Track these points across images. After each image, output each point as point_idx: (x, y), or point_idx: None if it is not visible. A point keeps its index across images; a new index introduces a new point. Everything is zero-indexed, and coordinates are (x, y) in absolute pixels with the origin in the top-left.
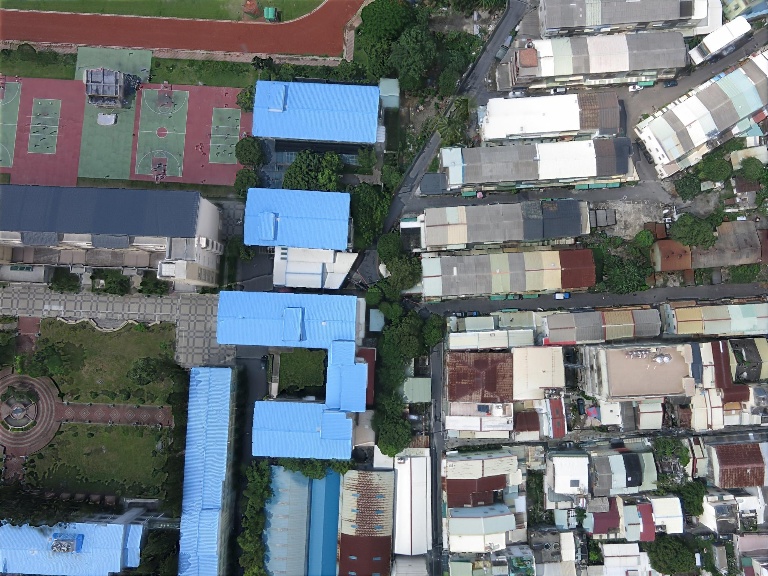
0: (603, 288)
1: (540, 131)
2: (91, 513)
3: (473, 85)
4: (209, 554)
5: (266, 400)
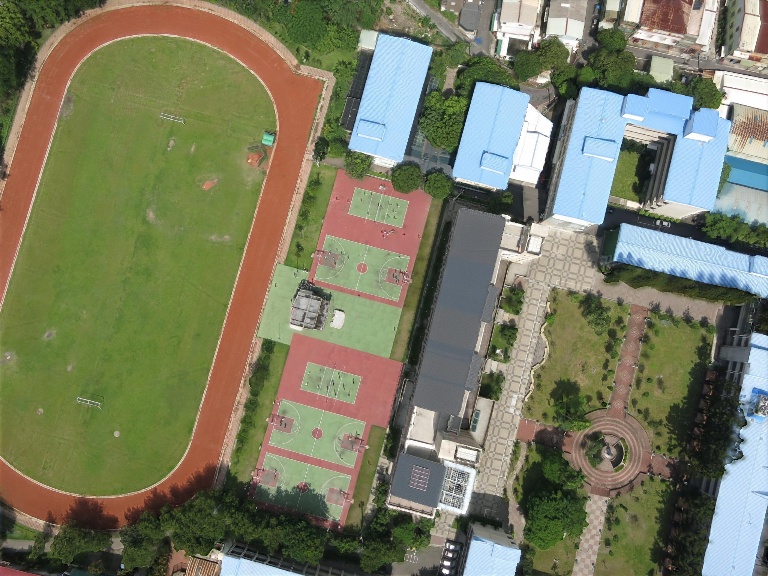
0: None
1: None
2: None
3: None
4: None
5: (652, 202)
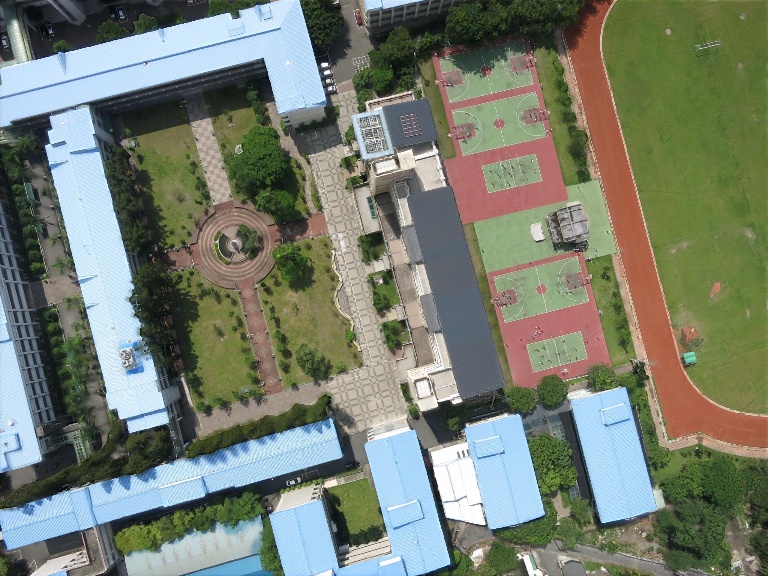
0: None
1: None
2: None
3: None
4: (163, 500)
5: None
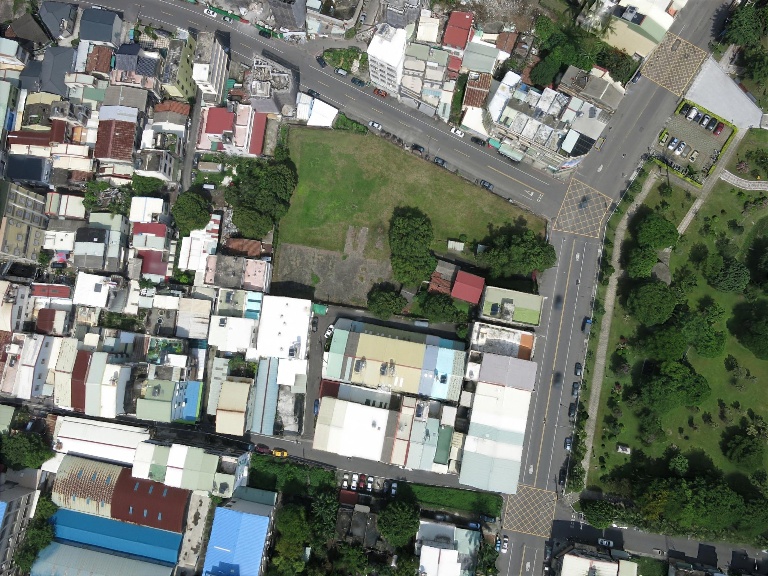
0: None
1: None
2: None
3: None
4: None
5: None
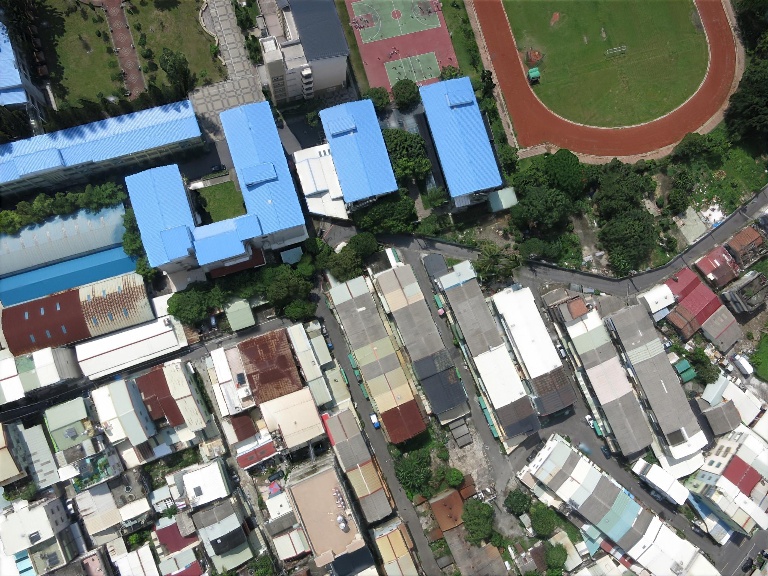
0: (395, 455)
1: (517, 343)
2: (25, 55)
3: (538, 273)
4: (18, 169)
5: None
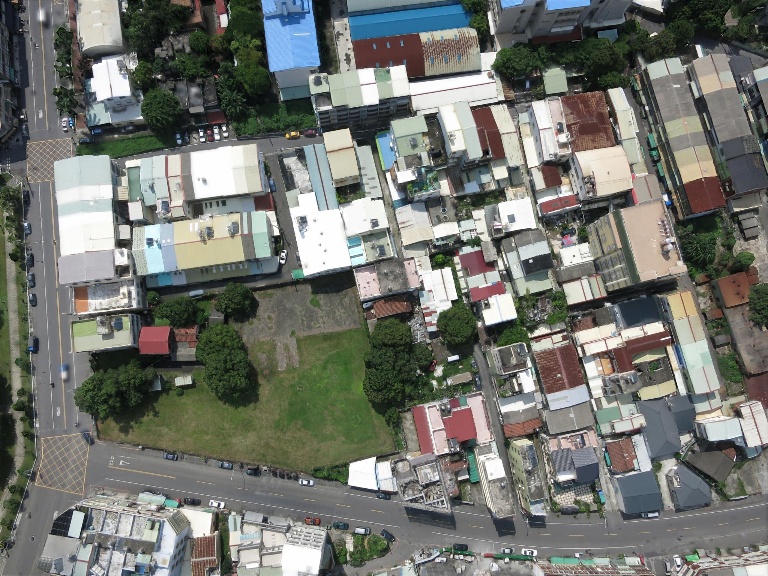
0: (687, 230)
1: None
2: None
3: None
4: None
5: None
